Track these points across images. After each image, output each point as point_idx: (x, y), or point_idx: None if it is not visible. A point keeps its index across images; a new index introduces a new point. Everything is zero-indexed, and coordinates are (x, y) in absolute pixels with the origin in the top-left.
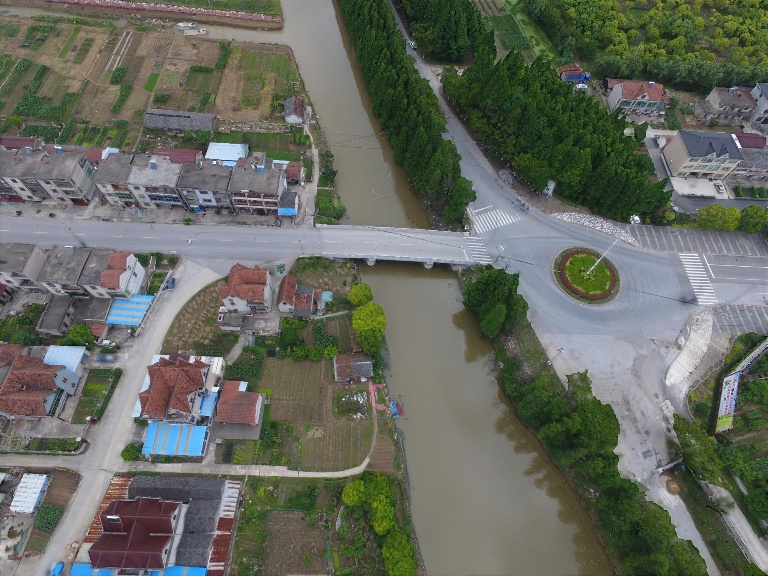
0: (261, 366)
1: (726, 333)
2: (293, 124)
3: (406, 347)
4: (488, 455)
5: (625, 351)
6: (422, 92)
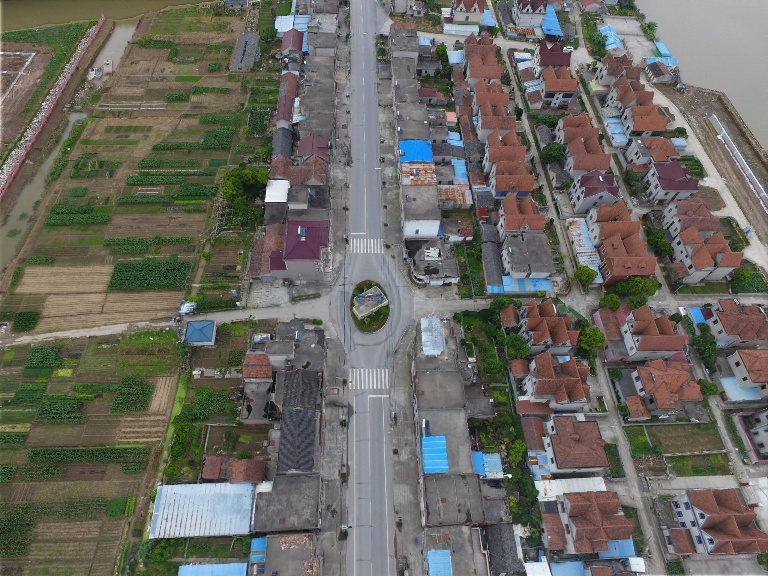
0: (440, 4)
1: None
2: (249, 7)
3: None
4: None
5: None
6: None
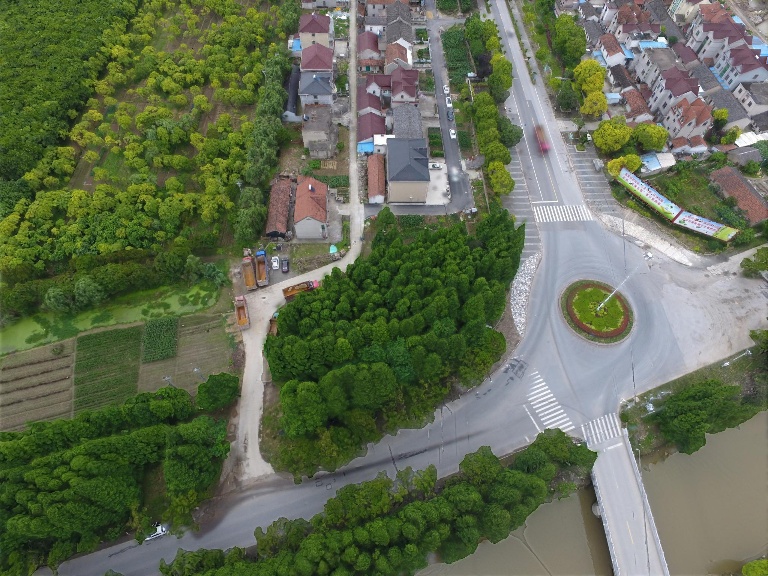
0: None
1: (617, 209)
2: None
3: (708, 526)
4: (765, 431)
5: (673, 292)
6: (366, 514)
